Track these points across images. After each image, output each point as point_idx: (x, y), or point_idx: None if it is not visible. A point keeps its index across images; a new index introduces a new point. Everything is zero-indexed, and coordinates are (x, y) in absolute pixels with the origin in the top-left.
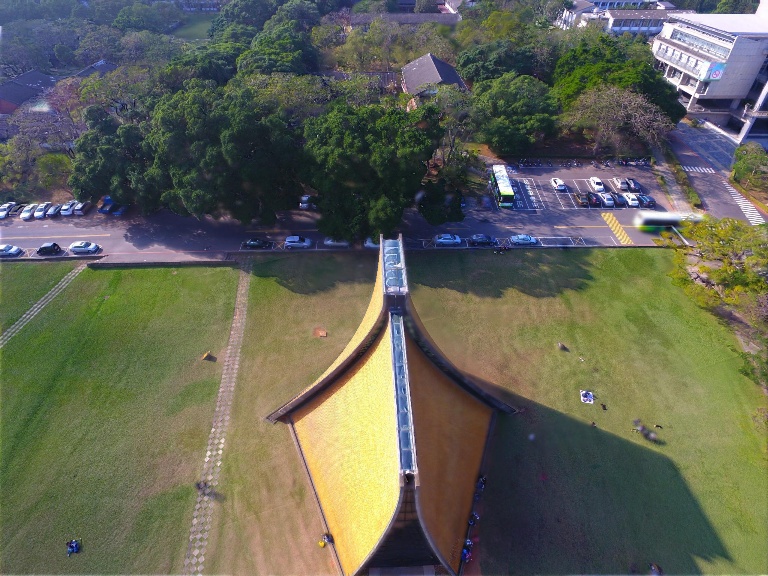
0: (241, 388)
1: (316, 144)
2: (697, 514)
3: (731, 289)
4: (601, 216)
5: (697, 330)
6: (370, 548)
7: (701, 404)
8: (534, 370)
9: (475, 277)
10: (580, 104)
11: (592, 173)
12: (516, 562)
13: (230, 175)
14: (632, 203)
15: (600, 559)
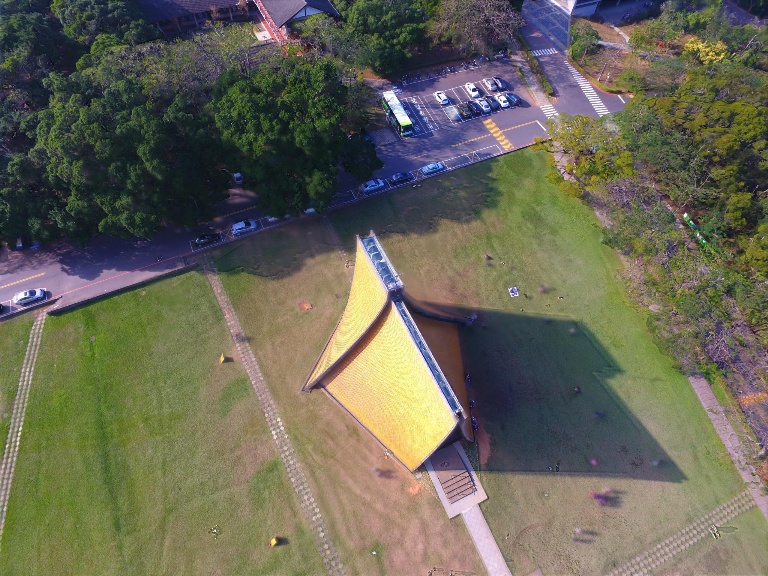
0: (268, 375)
1: (234, 133)
2: (592, 347)
3: (589, 179)
4: (484, 125)
5: (570, 214)
6: (429, 451)
7: (582, 272)
8: (474, 283)
9: (406, 216)
10: (444, 13)
11: (465, 77)
12: (503, 418)
13: (163, 189)
14: (504, 105)
15: (547, 396)
